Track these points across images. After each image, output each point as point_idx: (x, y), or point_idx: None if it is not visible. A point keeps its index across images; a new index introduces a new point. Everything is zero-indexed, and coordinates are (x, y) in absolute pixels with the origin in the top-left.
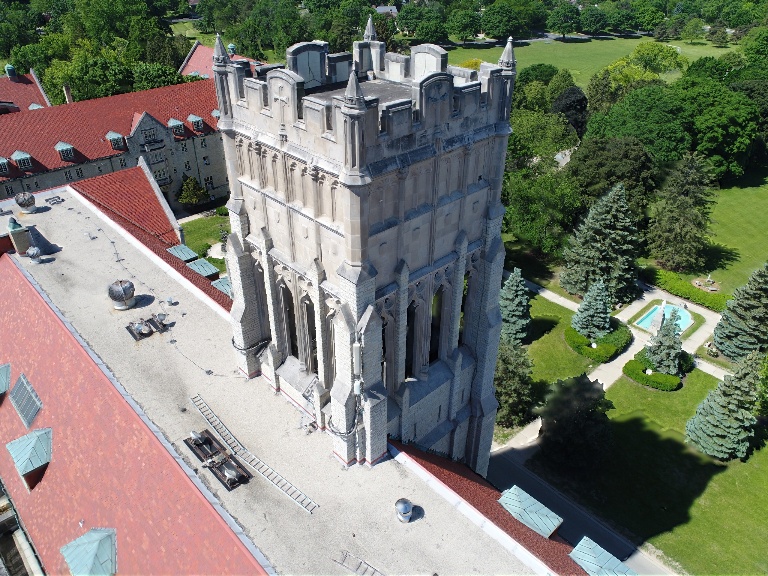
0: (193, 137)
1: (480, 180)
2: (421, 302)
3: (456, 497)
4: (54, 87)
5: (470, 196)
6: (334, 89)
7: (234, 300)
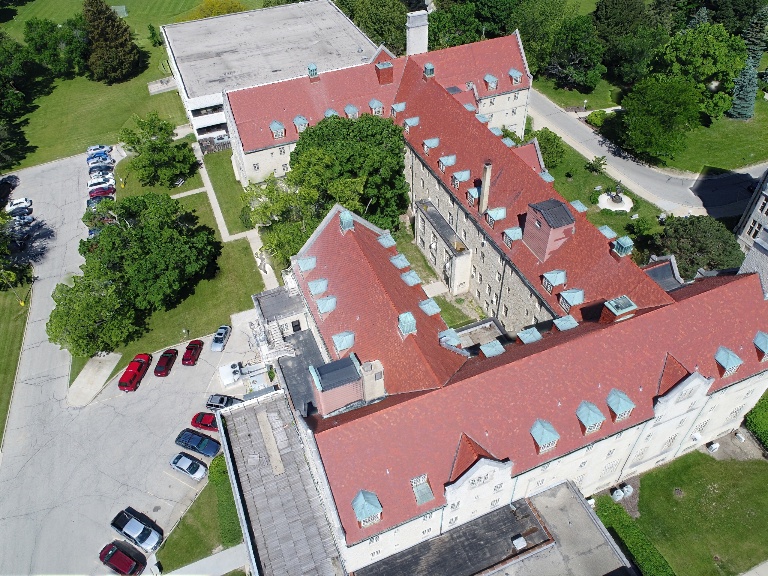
0: None
1: None
2: None
3: None
4: None
5: None
6: None
7: None
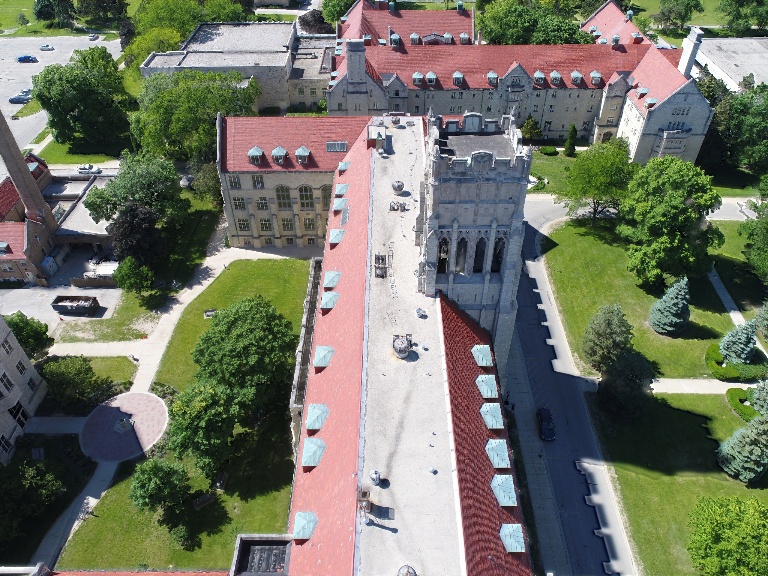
0: (548, 89)
1: (510, 199)
2: (469, 240)
3: (441, 320)
4: (482, 23)
5: (502, 204)
6: (482, 135)
7: None
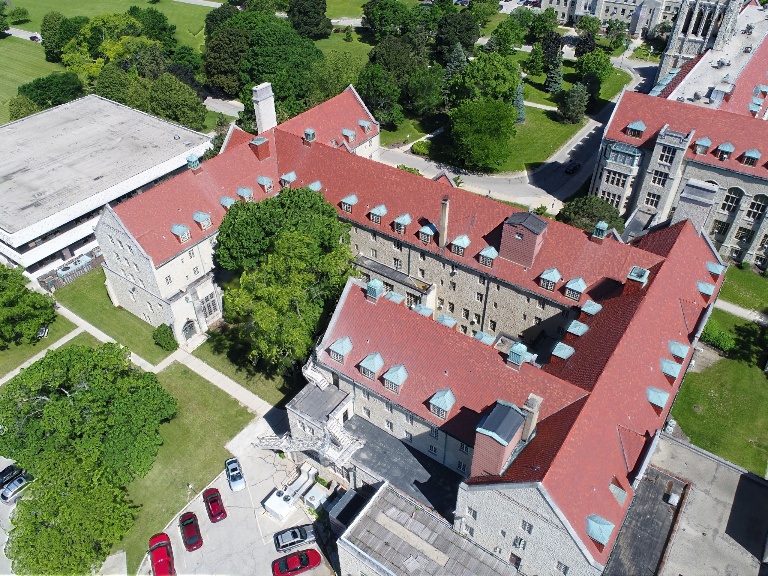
0: None
1: None
2: None
3: None
4: None
5: None
6: None
7: None
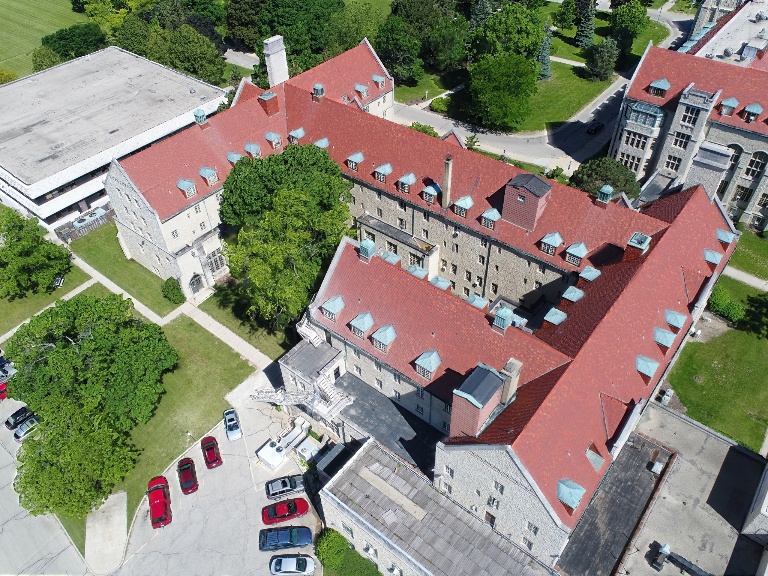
0: None
1: None
2: None
3: None
4: None
5: None
6: None
7: None
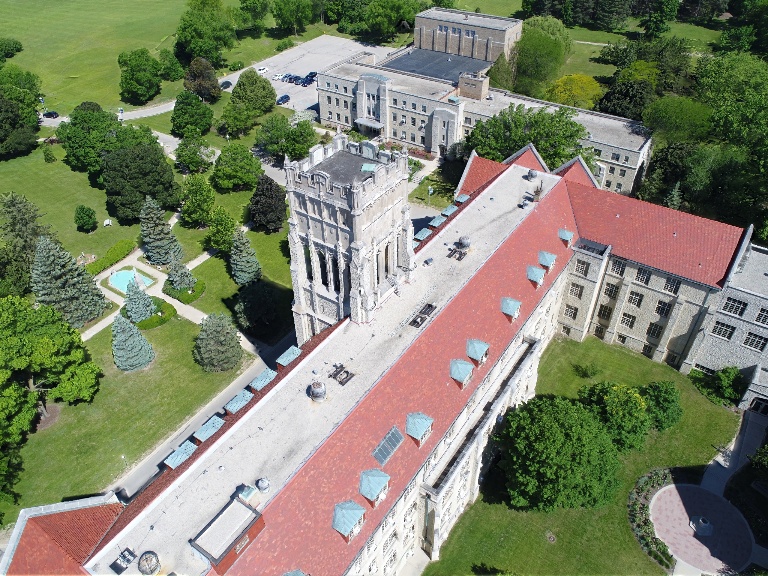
0: None
1: None
2: None
3: (419, 253)
4: None
5: None
6: None
7: (365, 291)
